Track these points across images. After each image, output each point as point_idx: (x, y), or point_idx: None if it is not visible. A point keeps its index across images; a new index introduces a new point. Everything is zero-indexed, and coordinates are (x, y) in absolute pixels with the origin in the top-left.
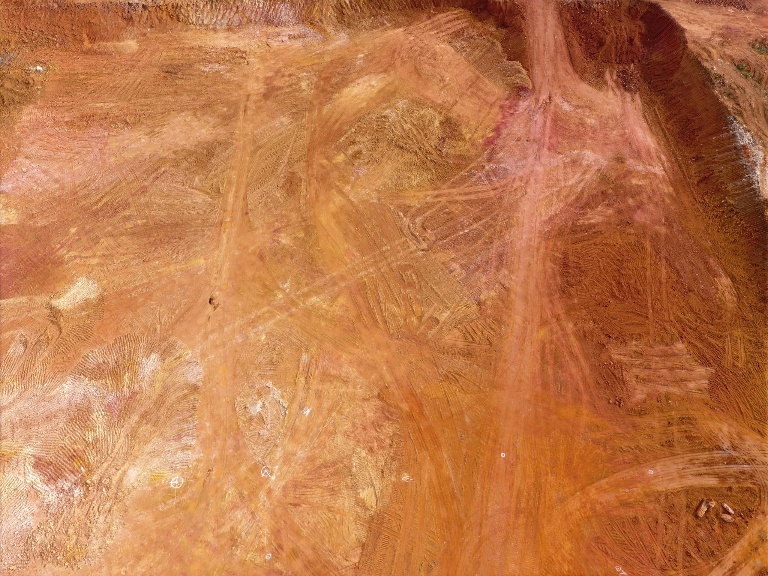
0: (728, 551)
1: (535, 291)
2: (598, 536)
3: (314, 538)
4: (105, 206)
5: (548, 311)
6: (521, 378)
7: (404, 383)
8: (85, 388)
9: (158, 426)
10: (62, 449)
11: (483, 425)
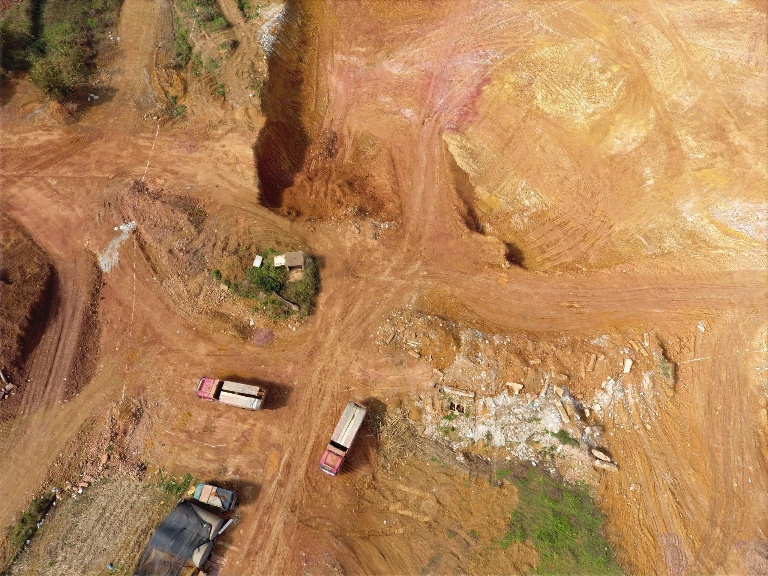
0: None
1: None
2: None
3: None
4: (767, 39)
5: None
6: None
7: None
8: None
9: None
10: None
11: None
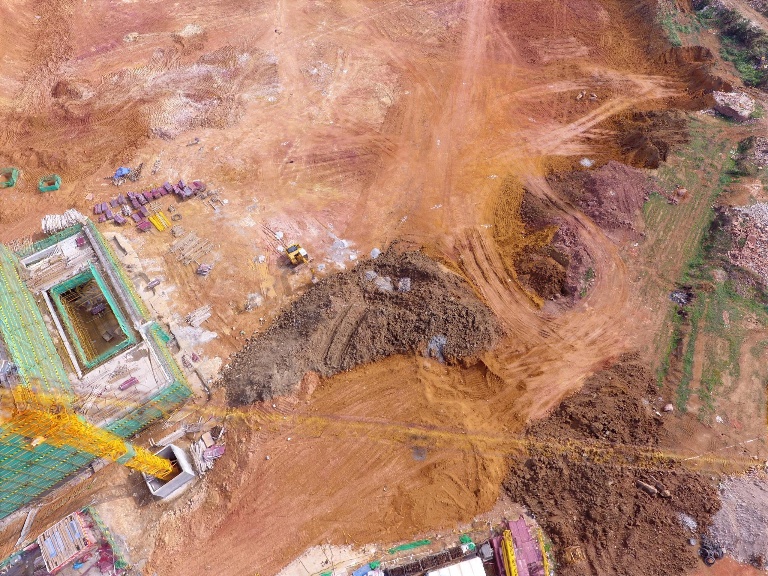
0: (592, 111)
1: (483, 20)
2: (519, 108)
3: (357, 115)
4: None
5: (491, 28)
6: (474, 54)
7: (403, 58)
8: (206, 68)
9: (256, 80)
10: (200, 90)
11: (452, 73)
